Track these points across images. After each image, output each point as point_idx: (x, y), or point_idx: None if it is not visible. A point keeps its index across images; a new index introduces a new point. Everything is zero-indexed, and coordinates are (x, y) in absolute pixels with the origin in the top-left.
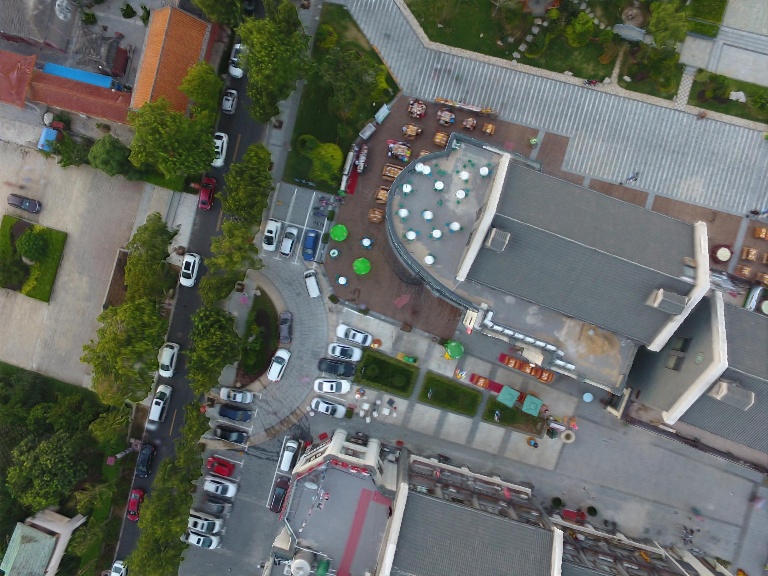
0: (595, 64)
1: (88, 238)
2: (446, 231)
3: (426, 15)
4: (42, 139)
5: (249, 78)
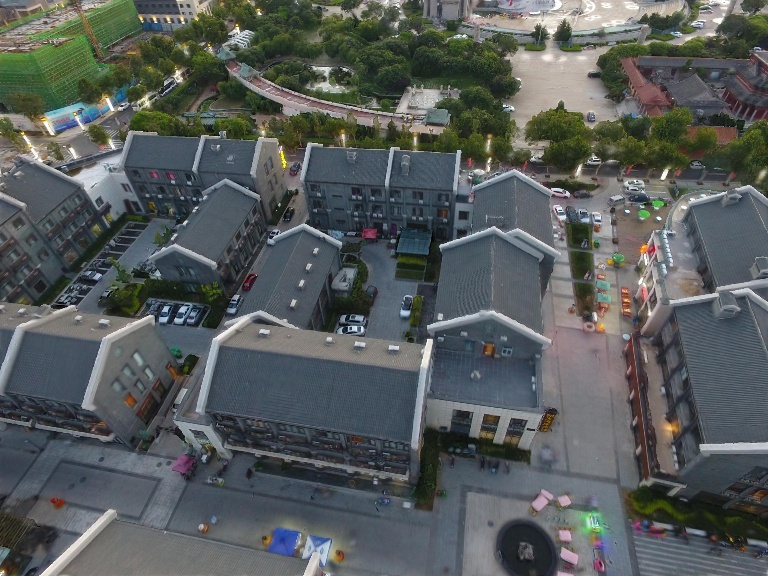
0: None
1: None
2: None
3: None
4: None
5: None
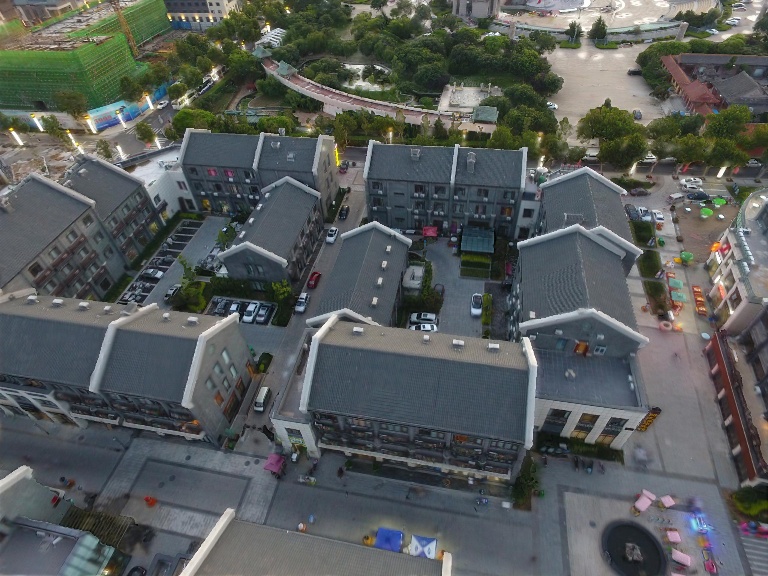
0: None
1: None
2: None
3: None
4: None
5: None
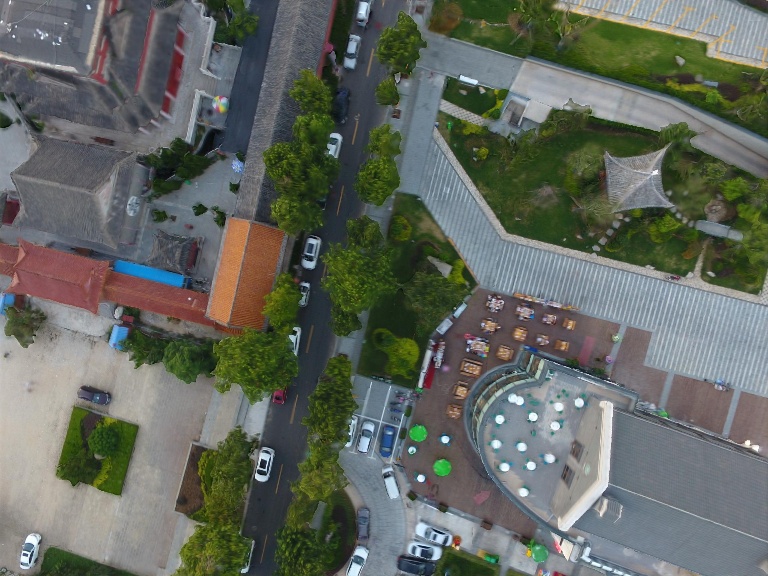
0: (678, 258)
1: (159, 430)
2: (540, 461)
3: (503, 207)
4: (114, 338)
5: (332, 296)
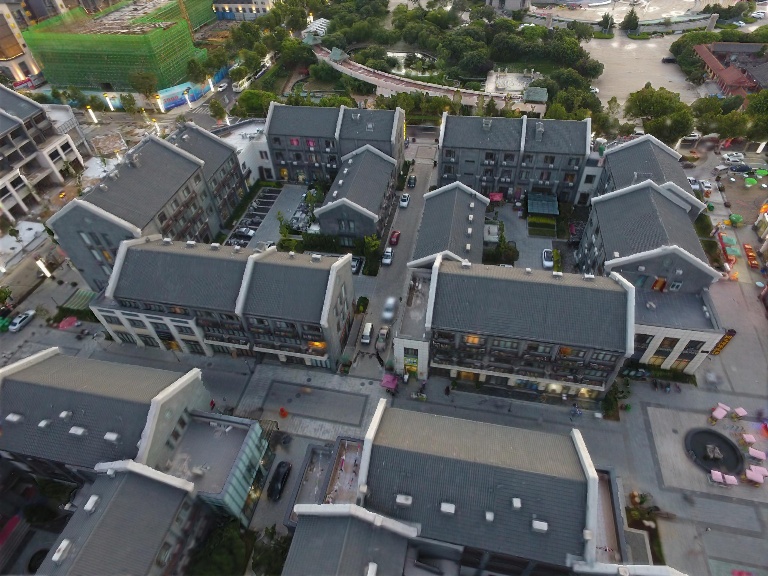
0: None
1: None
2: None
3: None
4: None
5: None
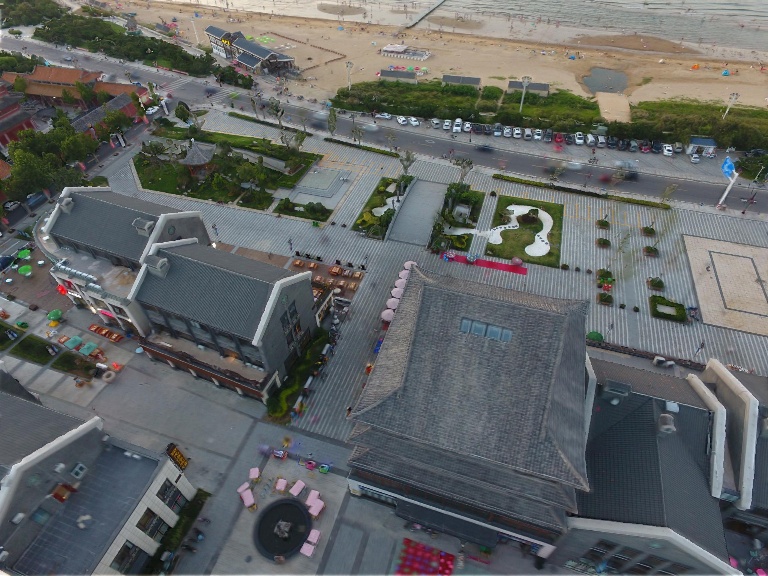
0: (226, 197)
1: None
2: None
3: (146, 180)
4: None
5: None
